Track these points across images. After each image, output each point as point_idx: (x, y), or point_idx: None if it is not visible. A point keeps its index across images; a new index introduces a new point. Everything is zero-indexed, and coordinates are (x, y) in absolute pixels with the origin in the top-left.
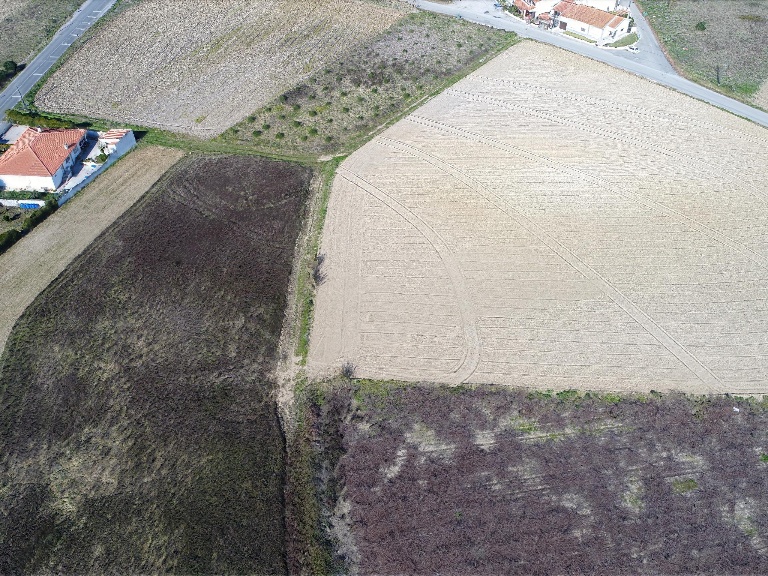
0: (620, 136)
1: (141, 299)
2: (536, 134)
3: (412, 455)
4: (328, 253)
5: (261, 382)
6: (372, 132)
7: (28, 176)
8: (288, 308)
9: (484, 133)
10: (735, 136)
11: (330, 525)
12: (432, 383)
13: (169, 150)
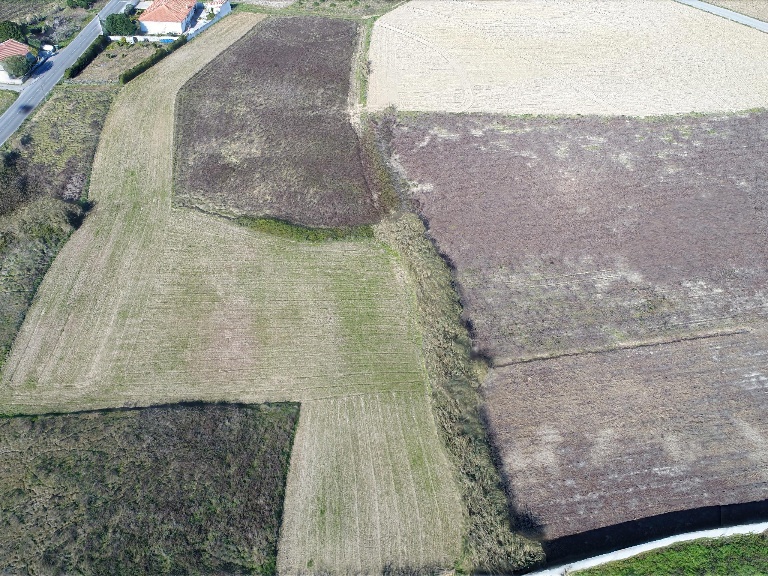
0: (572, 4)
1: (256, 81)
2: (513, 3)
3: (434, 138)
4: (374, 60)
5: (339, 114)
6: (397, 4)
7: (165, 22)
8: (351, 85)
9: (477, 3)
10: (652, 4)
11: (389, 162)
12: (445, 112)
13: (255, 14)
